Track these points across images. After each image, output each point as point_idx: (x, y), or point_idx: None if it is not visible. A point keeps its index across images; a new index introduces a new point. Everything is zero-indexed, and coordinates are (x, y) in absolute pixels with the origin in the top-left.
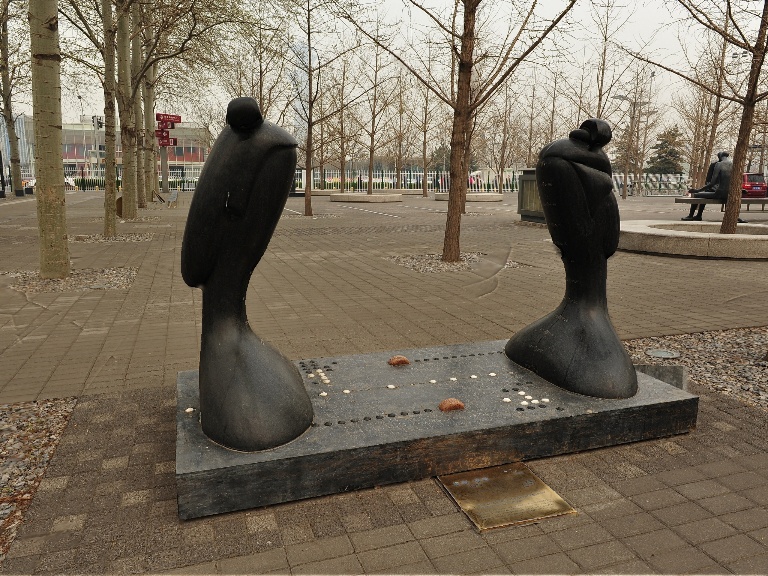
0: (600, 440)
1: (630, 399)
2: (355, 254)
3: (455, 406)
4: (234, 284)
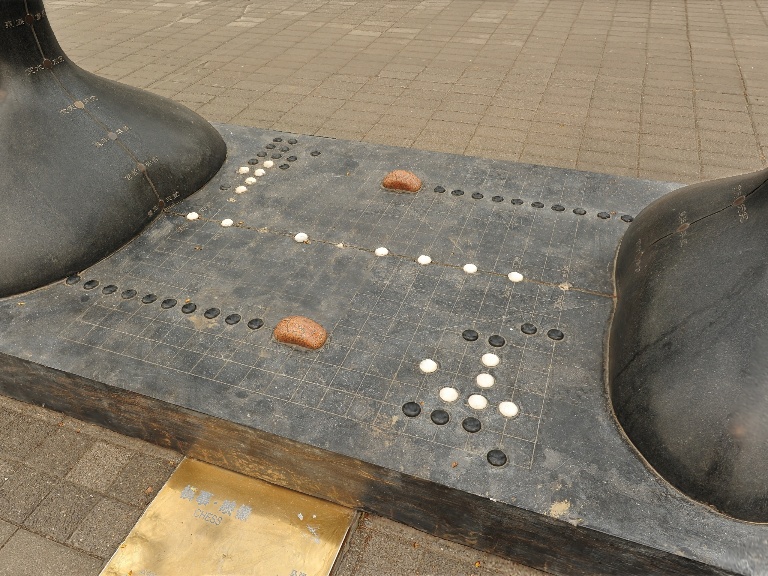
0: (577, 571)
1: (744, 528)
2: None
3: (294, 339)
4: None
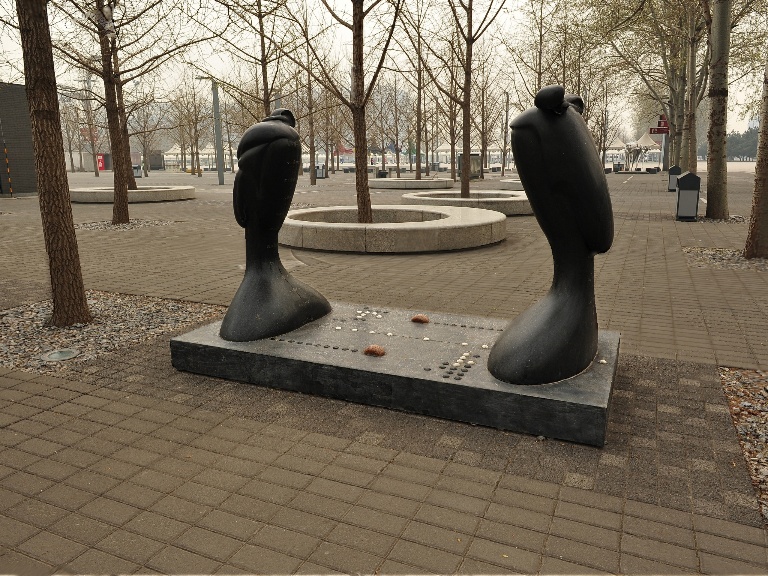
0: None
1: None
2: None
3: None
4: None
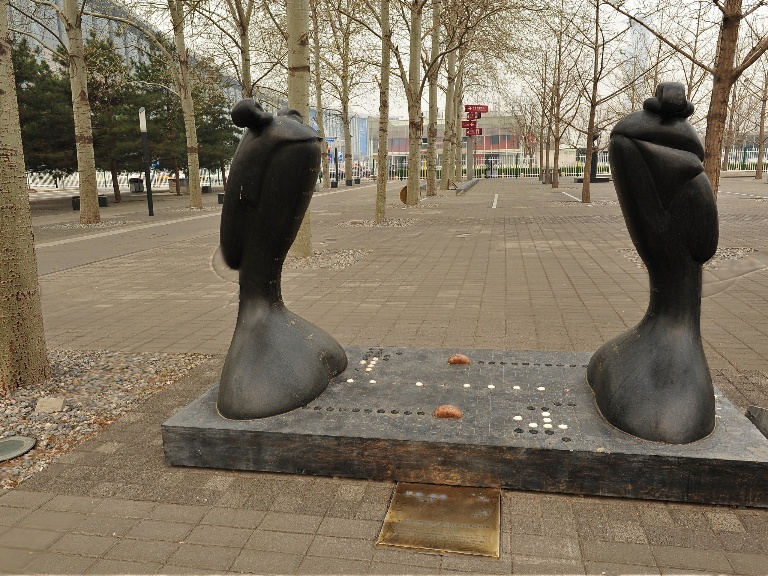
0: (615, 488)
1: (676, 446)
2: (590, 245)
3: (448, 414)
4: (259, 269)
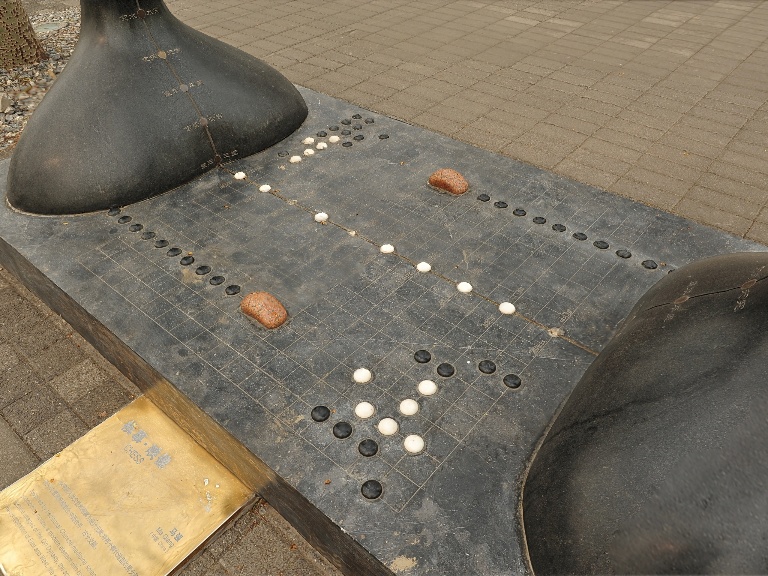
0: None
1: None
2: None
3: (253, 314)
4: None
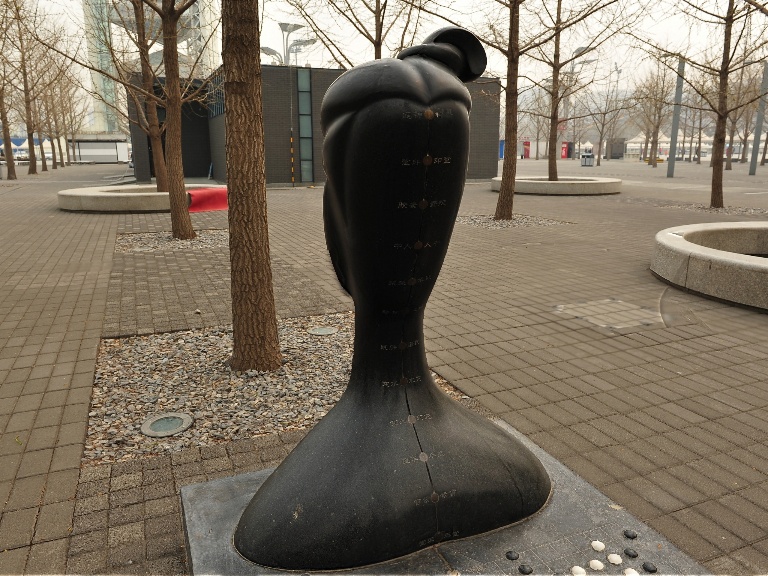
0: None
1: None
2: None
3: None
4: None
